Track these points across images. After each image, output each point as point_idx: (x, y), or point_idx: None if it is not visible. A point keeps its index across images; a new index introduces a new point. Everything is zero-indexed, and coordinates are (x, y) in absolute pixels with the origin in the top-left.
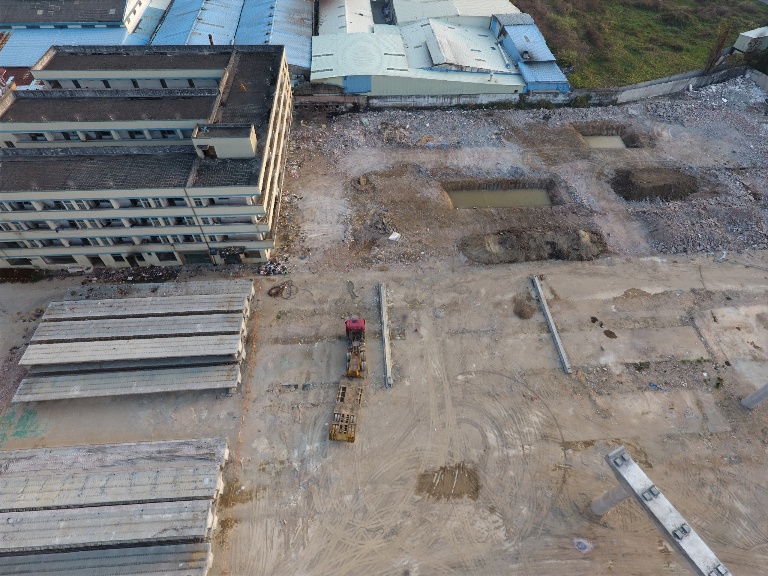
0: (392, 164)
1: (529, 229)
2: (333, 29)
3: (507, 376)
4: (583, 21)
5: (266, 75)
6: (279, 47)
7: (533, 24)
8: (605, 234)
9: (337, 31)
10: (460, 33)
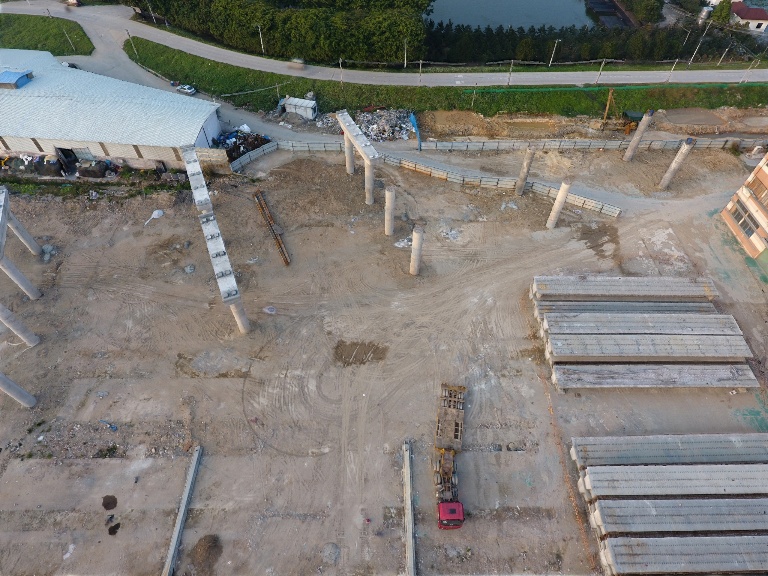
0: None
1: None
2: None
3: (272, 448)
4: None
5: None
6: None
7: None
8: None
9: None
10: None
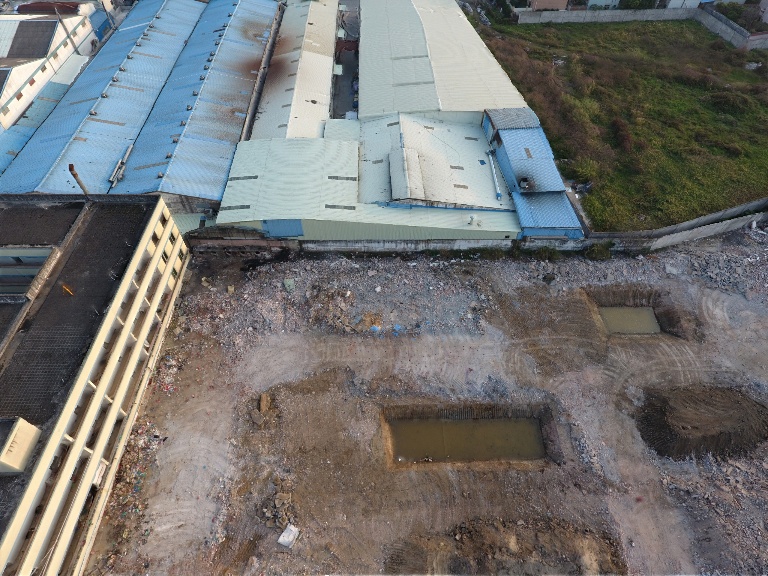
0: (314, 368)
1: (501, 542)
2: (270, 128)
3: None
4: (608, 104)
5: (117, 256)
6: (154, 197)
7: (538, 127)
8: (624, 540)
9: (274, 132)
10: (439, 136)
